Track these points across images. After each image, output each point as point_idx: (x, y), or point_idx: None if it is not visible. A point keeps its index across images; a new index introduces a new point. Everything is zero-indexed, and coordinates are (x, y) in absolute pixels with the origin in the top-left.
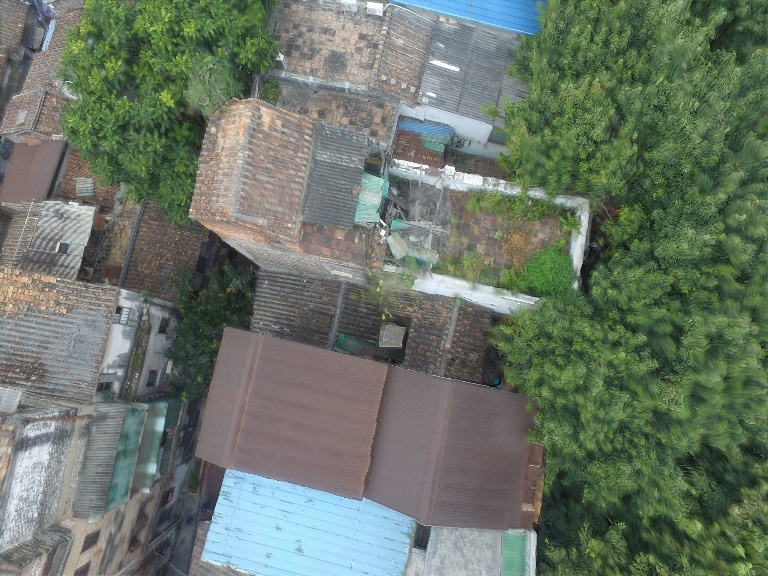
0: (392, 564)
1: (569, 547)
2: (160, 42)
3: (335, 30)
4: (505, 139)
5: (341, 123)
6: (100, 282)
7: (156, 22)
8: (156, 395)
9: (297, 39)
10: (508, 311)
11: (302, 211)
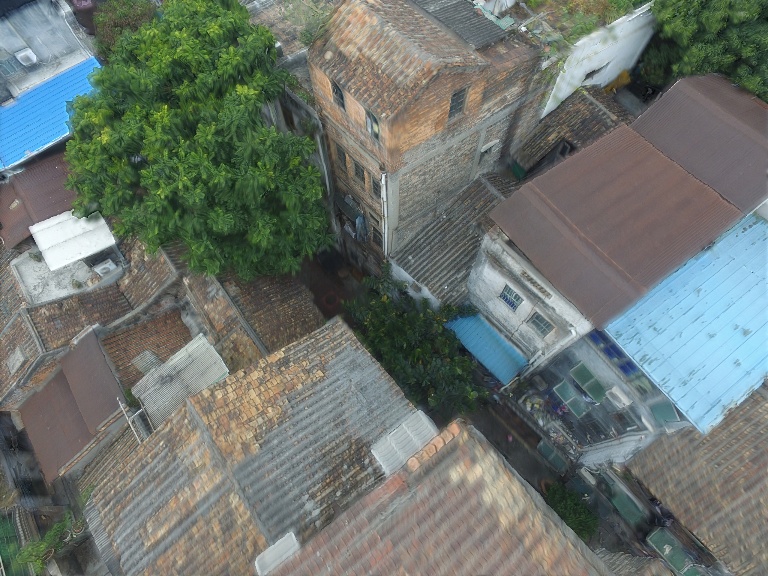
0: None
1: None
2: (194, 56)
3: None
4: None
5: None
6: None
7: (173, 48)
8: None
9: None
10: (616, 67)
11: (468, 43)
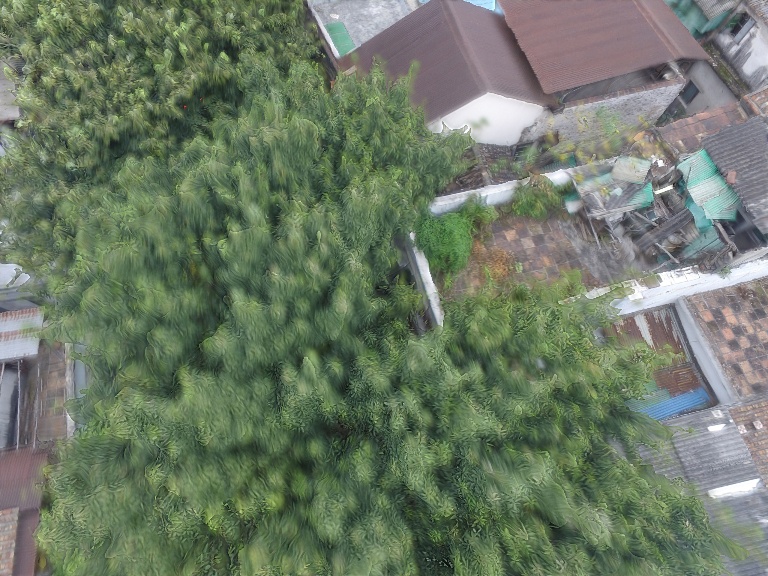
0: None
1: None
2: None
3: None
4: None
5: None
6: None
7: None
8: None
9: None
10: None
11: None
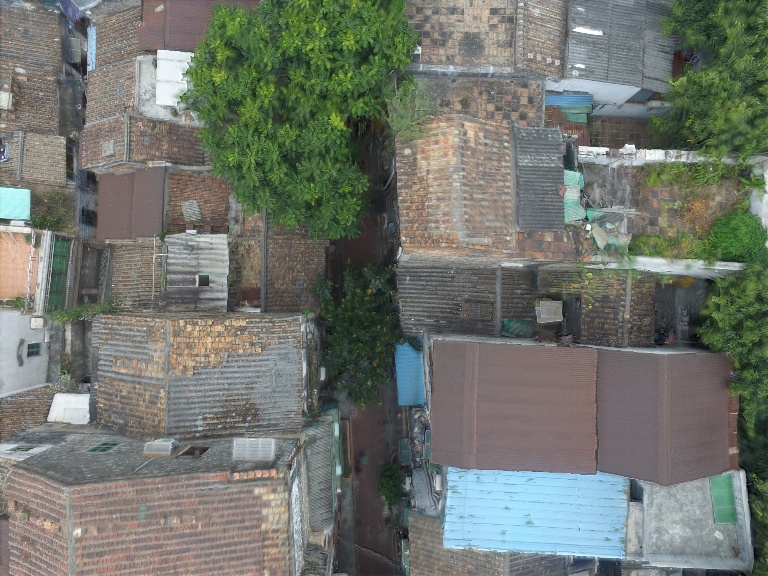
0: (615, 519)
1: (762, 475)
2: (318, 61)
3: (463, 8)
4: (645, 98)
5: (487, 110)
6: (239, 305)
7: (308, 39)
8: (321, 403)
9: (424, 25)
10: None
11: (517, 222)
